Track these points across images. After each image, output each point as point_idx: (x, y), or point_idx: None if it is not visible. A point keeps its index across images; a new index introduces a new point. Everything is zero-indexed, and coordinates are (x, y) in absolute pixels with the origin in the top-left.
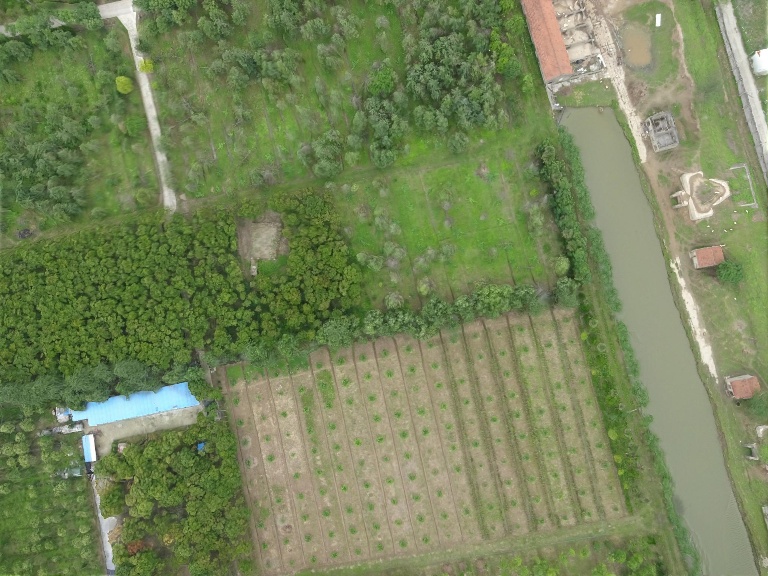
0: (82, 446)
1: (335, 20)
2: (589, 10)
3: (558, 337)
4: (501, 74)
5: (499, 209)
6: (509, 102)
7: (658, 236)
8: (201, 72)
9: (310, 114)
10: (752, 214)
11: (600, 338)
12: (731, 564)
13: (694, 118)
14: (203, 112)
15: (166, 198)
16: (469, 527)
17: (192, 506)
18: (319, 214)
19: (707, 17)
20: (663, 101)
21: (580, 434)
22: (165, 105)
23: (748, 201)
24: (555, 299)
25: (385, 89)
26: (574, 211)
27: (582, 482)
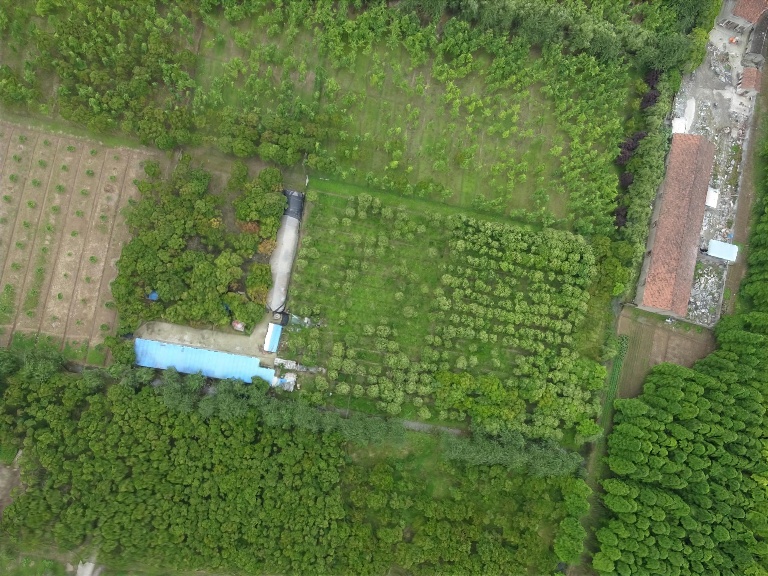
0: None
1: None
2: None
3: None
4: None
5: None
6: None
7: None
8: None
9: None
10: None
11: None
12: None
13: None
14: None
15: (88, 573)
16: None
17: (173, 243)
18: None
19: None
20: None
21: None
22: None
23: None
24: None
25: None
26: None
27: None
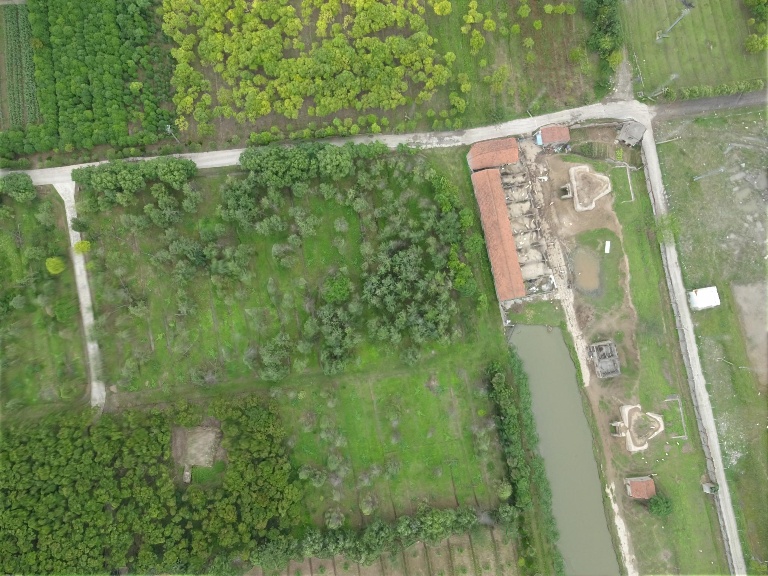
0: None
1: (293, 221)
2: (544, 230)
3: (496, 558)
4: (457, 290)
5: (446, 424)
6: (463, 318)
7: (596, 459)
8: (144, 258)
9: (260, 313)
10: (682, 445)
11: (536, 561)
12: None
13: (635, 348)
14: (143, 300)
15: (94, 389)
16: None
17: None
18: (262, 428)
19: (652, 249)
20: (608, 328)
21: None
22: (101, 287)
23: (679, 434)
24: (495, 520)
25: (340, 298)
26: (519, 437)
27: None
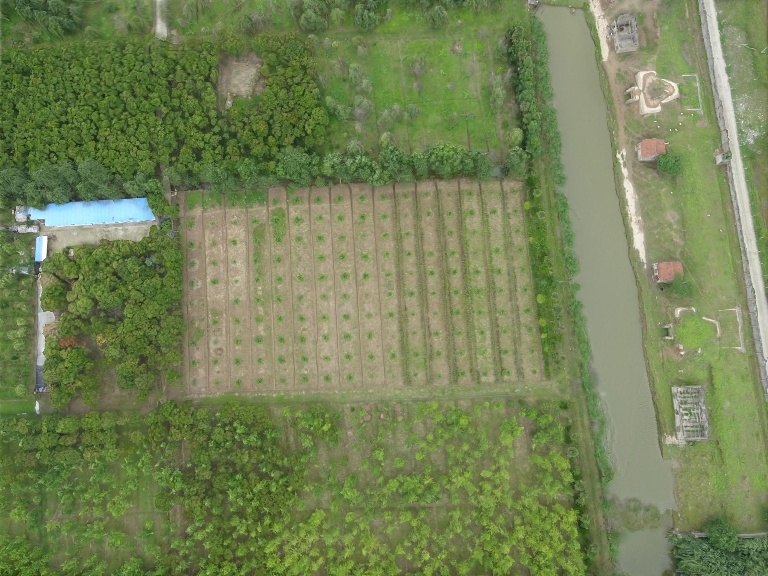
0: (35, 247)
1: None
2: None
3: (504, 206)
4: None
5: (466, 84)
6: None
7: (609, 129)
8: None
9: None
10: (697, 119)
11: None
12: (636, 439)
13: (655, 27)
14: None
15: (158, 31)
16: (393, 372)
17: (130, 308)
18: (298, 57)
19: None
20: (630, 8)
21: (511, 298)
22: None
23: (695, 106)
24: (506, 171)
25: None
26: (534, 90)
27: (506, 343)
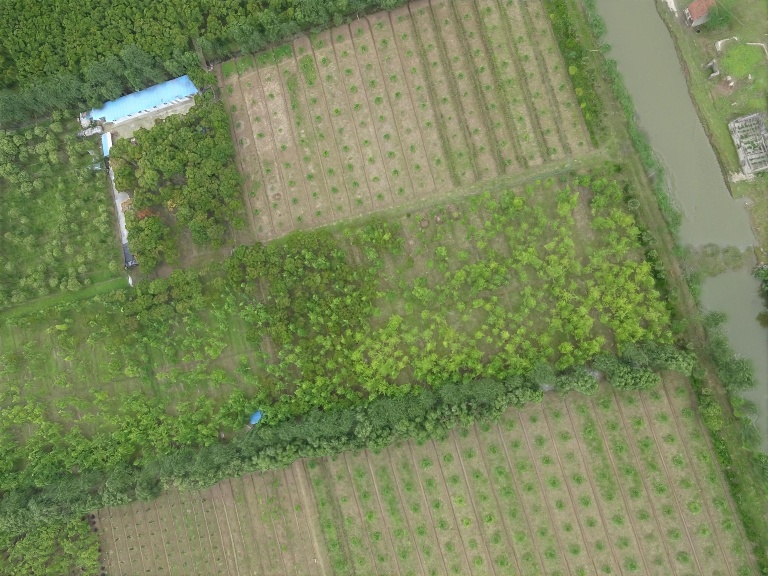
0: (102, 144)
1: None
2: None
3: None
4: None
5: None
6: None
7: None
8: None
9: None
10: None
11: None
12: (700, 186)
13: None
14: None
15: None
16: (441, 177)
17: (190, 169)
18: None
19: None
20: None
21: (544, 81)
22: None
23: None
24: None
25: None
26: None
27: (547, 124)
